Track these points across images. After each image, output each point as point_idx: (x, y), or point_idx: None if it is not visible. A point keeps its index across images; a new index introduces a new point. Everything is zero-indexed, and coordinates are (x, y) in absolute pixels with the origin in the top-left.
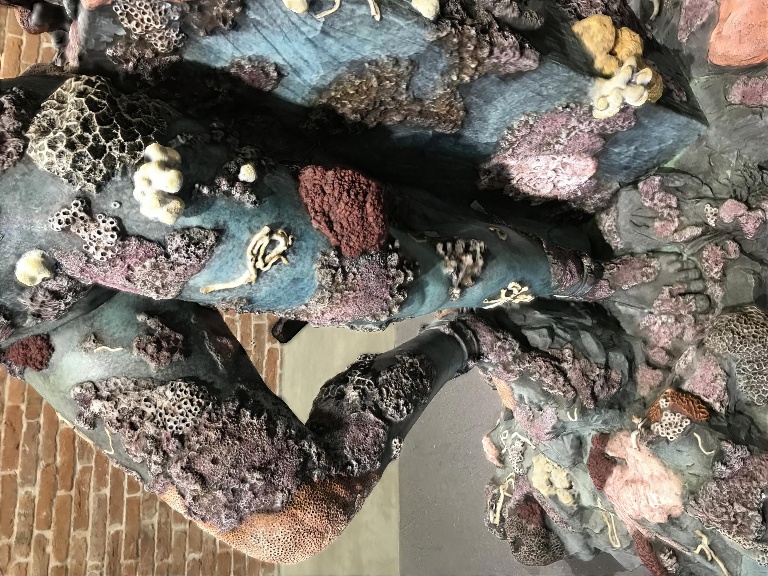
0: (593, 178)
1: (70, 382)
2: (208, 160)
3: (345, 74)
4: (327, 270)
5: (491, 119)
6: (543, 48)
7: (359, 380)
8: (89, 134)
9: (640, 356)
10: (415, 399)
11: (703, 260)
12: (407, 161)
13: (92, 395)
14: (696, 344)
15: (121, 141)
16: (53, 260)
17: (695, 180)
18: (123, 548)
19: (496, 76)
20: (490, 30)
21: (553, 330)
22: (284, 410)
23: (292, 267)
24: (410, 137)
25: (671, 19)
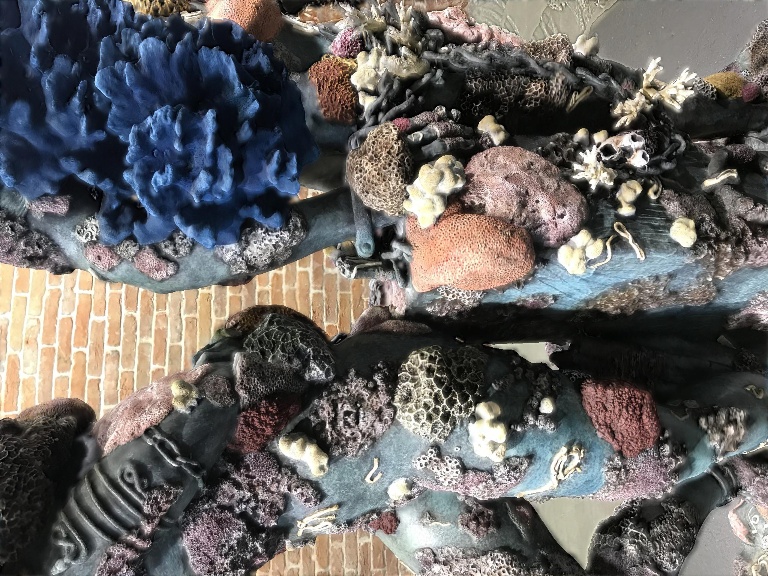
0: None
1: (413, 546)
2: (516, 399)
3: (610, 290)
4: (612, 472)
5: (742, 290)
6: None
7: (632, 532)
8: (440, 406)
9: None
10: (684, 549)
11: None
12: (658, 323)
13: (432, 559)
14: None
15: (459, 405)
16: (412, 482)
17: None
18: (372, 558)
19: (749, 268)
20: (744, 239)
21: None
22: (576, 569)
23: (584, 473)
24: (663, 311)
25: None
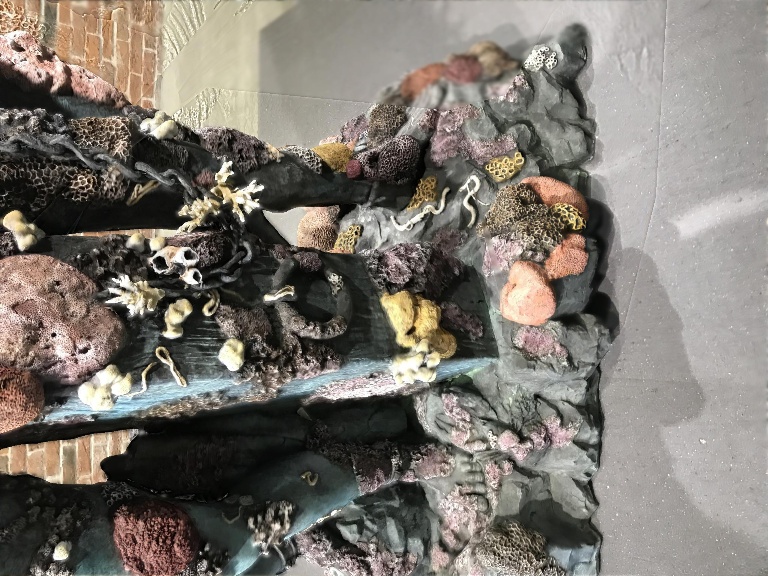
0: (405, 385)
1: None
2: (23, 549)
3: (161, 404)
4: None
5: (305, 386)
6: (346, 346)
7: None
8: None
9: (435, 535)
10: None
11: (485, 471)
12: None
13: None
14: (471, 549)
15: None
16: None
17: (484, 404)
18: None
19: None
20: (294, 357)
21: (363, 522)
22: None
23: None
24: None
25: (479, 247)
